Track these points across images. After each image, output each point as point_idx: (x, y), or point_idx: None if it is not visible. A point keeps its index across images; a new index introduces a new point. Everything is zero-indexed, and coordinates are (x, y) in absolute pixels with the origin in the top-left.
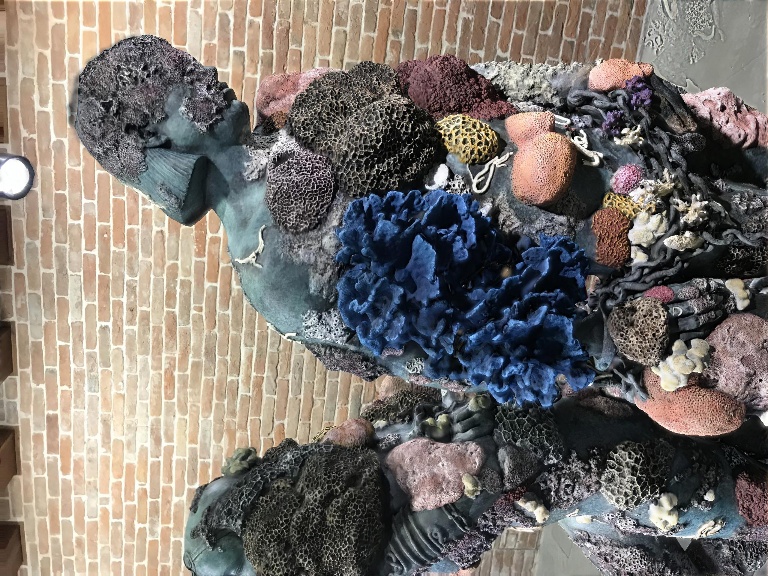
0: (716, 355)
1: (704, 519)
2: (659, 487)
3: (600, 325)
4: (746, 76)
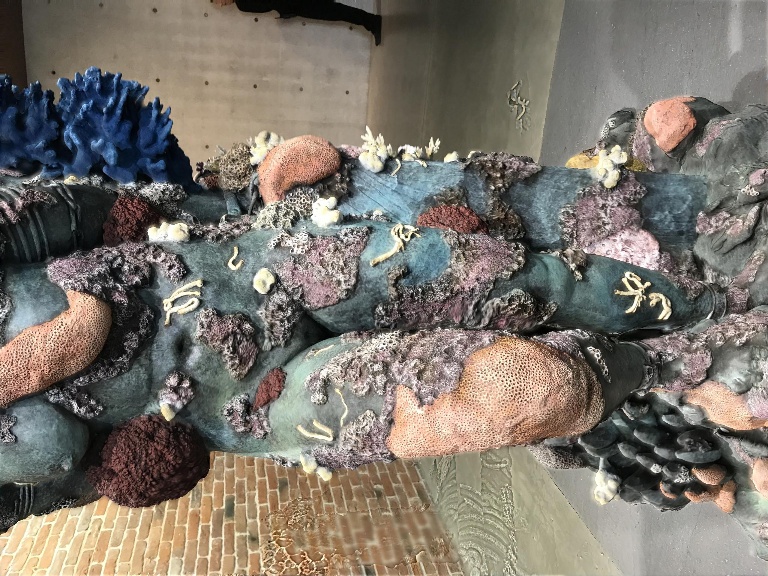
0: None
1: None
2: None
3: None
4: (561, 565)
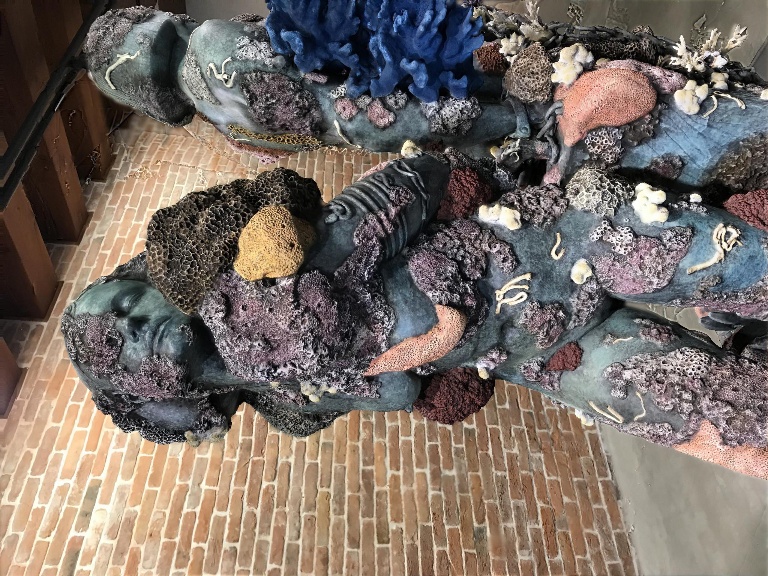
0: None
1: (709, 224)
2: None
3: (505, 102)
4: None
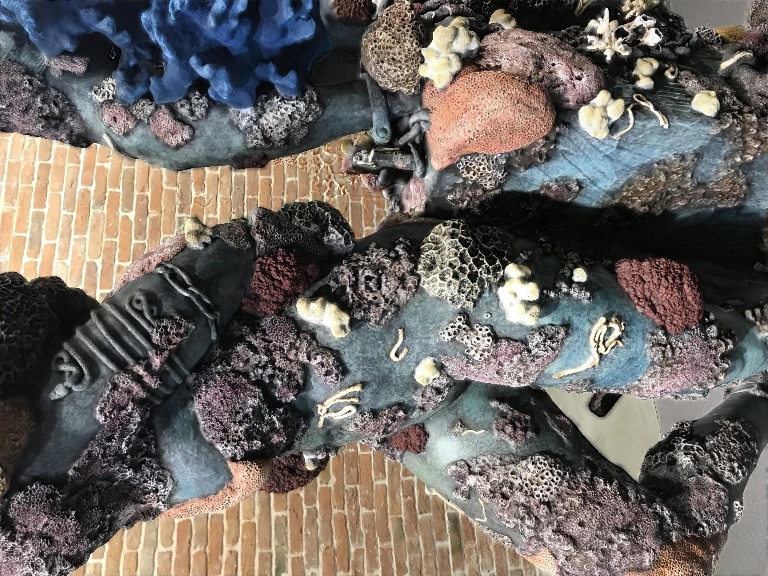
0: (490, 48)
1: (589, 316)
2: (499, 259)
3: (361, 81)
4: None
